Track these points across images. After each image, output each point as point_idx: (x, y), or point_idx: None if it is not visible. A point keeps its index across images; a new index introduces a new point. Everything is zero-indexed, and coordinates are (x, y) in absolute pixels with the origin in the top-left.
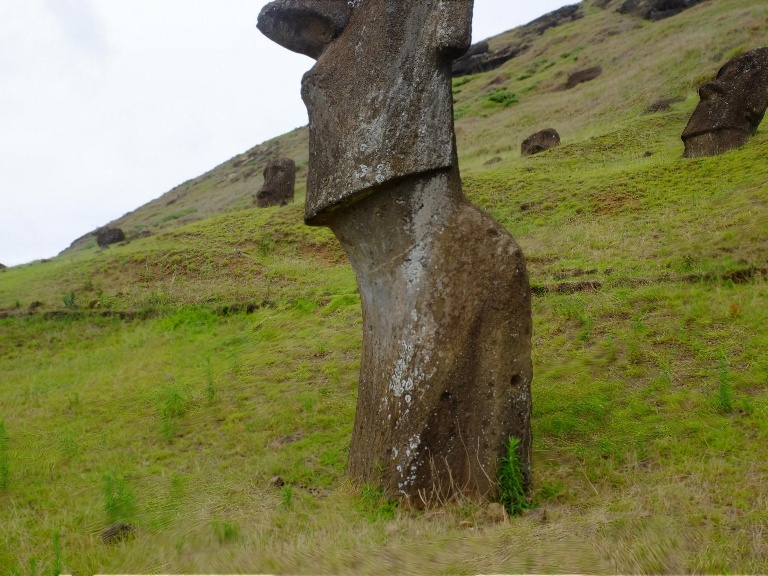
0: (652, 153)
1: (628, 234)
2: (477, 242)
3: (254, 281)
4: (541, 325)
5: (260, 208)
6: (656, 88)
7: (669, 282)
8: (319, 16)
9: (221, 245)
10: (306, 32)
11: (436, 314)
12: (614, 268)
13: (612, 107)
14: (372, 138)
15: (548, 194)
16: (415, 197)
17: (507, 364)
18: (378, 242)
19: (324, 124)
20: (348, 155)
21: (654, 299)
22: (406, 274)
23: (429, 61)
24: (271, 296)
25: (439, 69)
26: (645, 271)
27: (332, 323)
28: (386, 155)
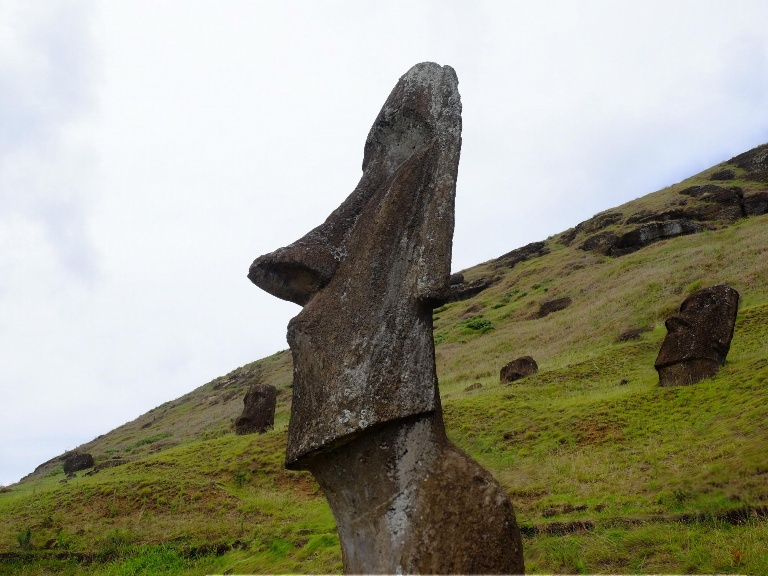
0: (628, 381)
1: (614, 466)
2: (463, 490)
3: (227, 516)
4: (534, 572)
5: (239, 435)
6: (624, 318)
7: (663, 523)
8: (307, 269)
9: (195, 475)
10: (294, 282)
11: (423, 572)
12: (604, 504)
13: (584, 335)
14: (356, 383)
15: (530, 423)
16: (399, 442)
17: None
18: (361, 489)
19: (309, 368)
20: (332, 400)
21: (650, 543)
22: (390, 525)
23: (411, 310)
24: (244, 534)
25: (420, 318)
26: (637, 508)
27: (309, 568)
28: (370, 400)
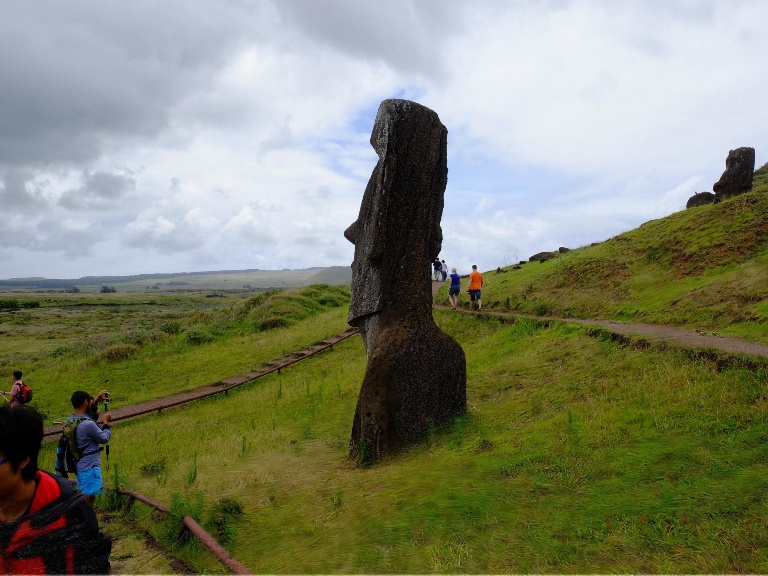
0: None
1: None
2: None
3: (610, 293)
4: None
5: (701, 205)
6: None
7: None
8: None
9: (631, 252)
10: None
11: None
12: None
13: None
14: None
15: None
16: (366, 325)
17: (364, 407)
18: None
19: None
20: None
21: (622, 368)
22: None
23: (368, 263)
24: (599, 309)
25: (373, 266)
26: None
27: None
28: (352, 308)
